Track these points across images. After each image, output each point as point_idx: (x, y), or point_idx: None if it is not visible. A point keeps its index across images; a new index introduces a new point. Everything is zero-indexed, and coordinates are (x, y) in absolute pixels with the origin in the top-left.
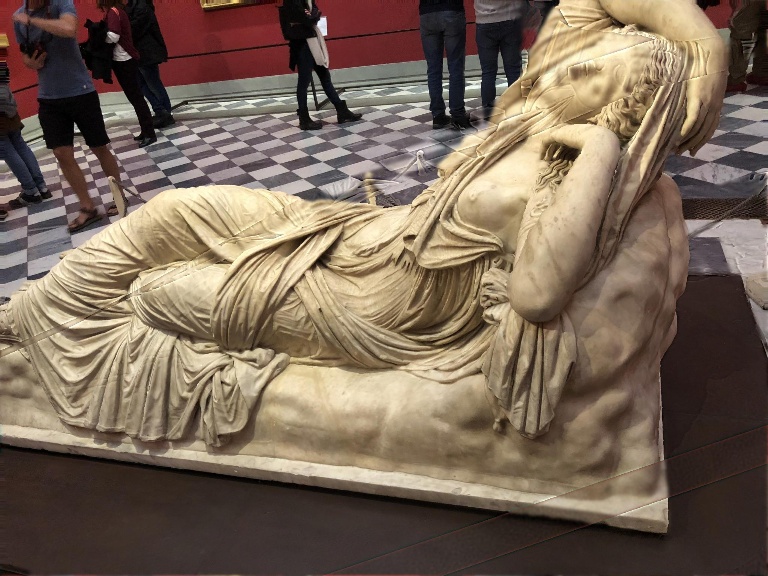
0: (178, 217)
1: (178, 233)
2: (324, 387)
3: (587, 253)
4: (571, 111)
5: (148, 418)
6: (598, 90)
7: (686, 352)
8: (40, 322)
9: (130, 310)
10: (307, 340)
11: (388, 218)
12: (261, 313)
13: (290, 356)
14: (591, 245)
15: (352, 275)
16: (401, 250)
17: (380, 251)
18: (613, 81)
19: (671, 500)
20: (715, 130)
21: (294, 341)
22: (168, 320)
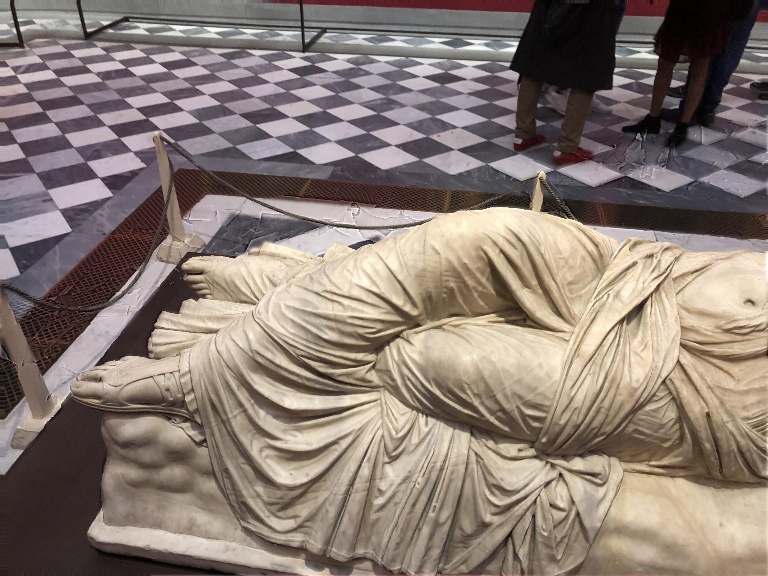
0: (482, 259)
1: (476, 281)
2: (690, 513)
3: None
4: None
5: (428, 549)
6: None
7: None
8: (240, 396)
9: (380, 383)
10: (661, 446)
11: (746, 277)
12: (625, 415)
13: (620, 461)
14: None
15: (721, 358)
16: None
17: (766, 330)
18: None
19: None
20: None
21: (641, 446)
22: (475, 414)
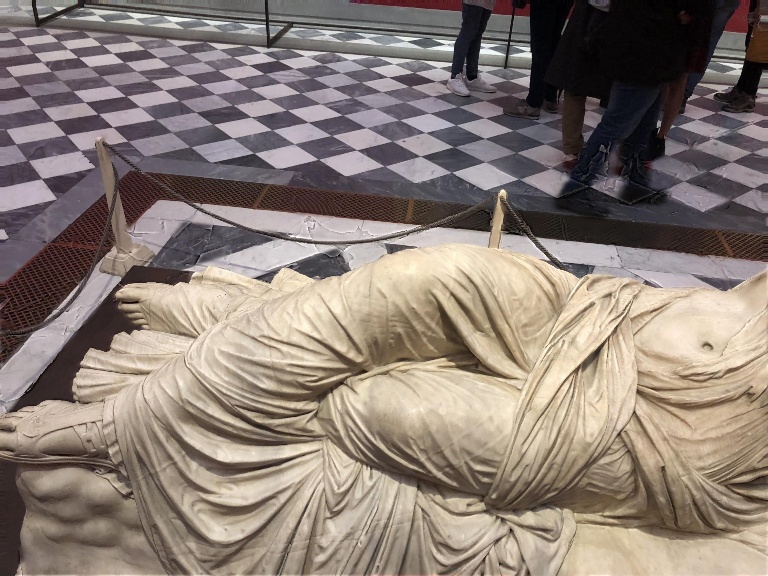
0: (431, 303)
1: (424, 326)
2: (644, 569)
3: None
4: None
5: None
6: None
7: None
8: (169, 449)
9: (322, 433)
10: (615, 498)
11: (705, 319)
12: (579, 470)
13: (573, 512)
14: None
15: (678, 406)
16: (765, 383)
17: (724, 377)
18: None
19: None
20: (734, 147)
21: (595, 498)
22: (421, 470)
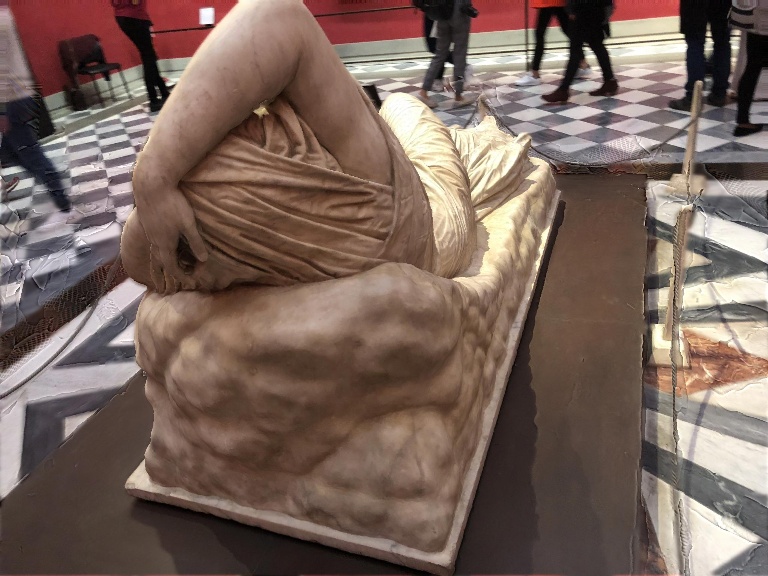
0: None
1: None
2: None
3: (123, 253)
4: None
5: None
6: None
7: None
8: None
9: None
10: None
11: None
12: None
13: None
14: (124, 251)
15: None
16: None
17: None
18: None
19: (168, 519)
20: None
21: None
22: None
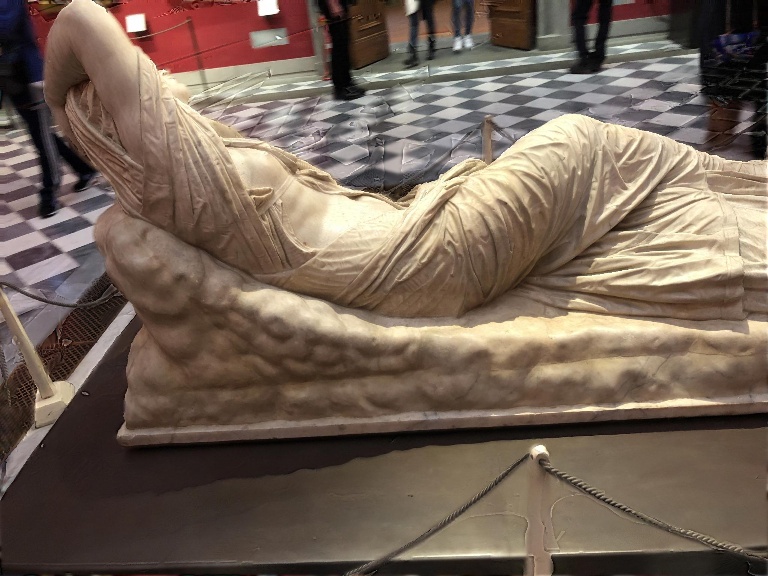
0: None
1: None
2: None
3: None
4: (217, 6)
5: None
6: (206, 5)
7: (121, 415)
8: None
9: None
10: None
11: (362, 202)
12: None
13: None
14: None
15: None
16: None
17: None
18: (199, 6)
19: None
20: None
21: None
22: None
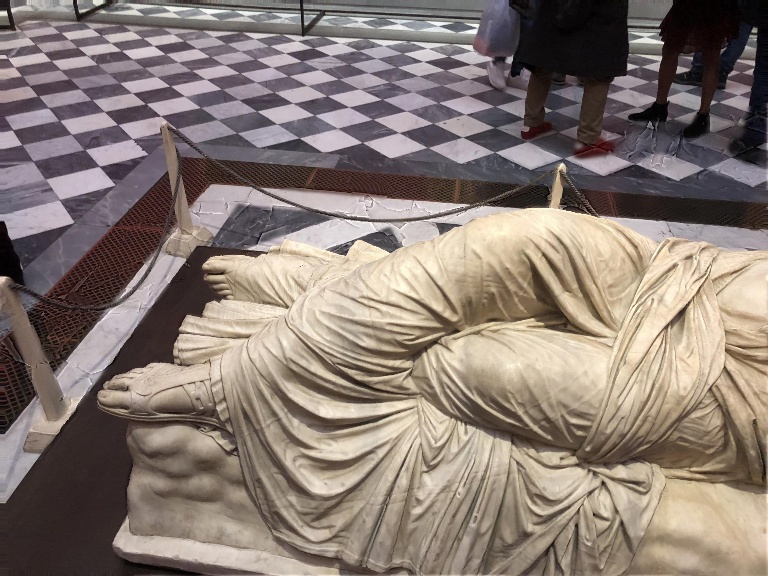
0: (524, 263)
1: (517, 286)
2: (733, 521)
3: None
4: None
5: (468, 560)
6: None
7: None
8: (274, 405)
9: (417, 391)
10: (704, 452)
11: None
12: (672, 423)
13: (661, 467)
14: None
15: (765, 363)
16: None
17: None
18: None
19: None
20: None
21: (684, 453)
22: (518, 423)
